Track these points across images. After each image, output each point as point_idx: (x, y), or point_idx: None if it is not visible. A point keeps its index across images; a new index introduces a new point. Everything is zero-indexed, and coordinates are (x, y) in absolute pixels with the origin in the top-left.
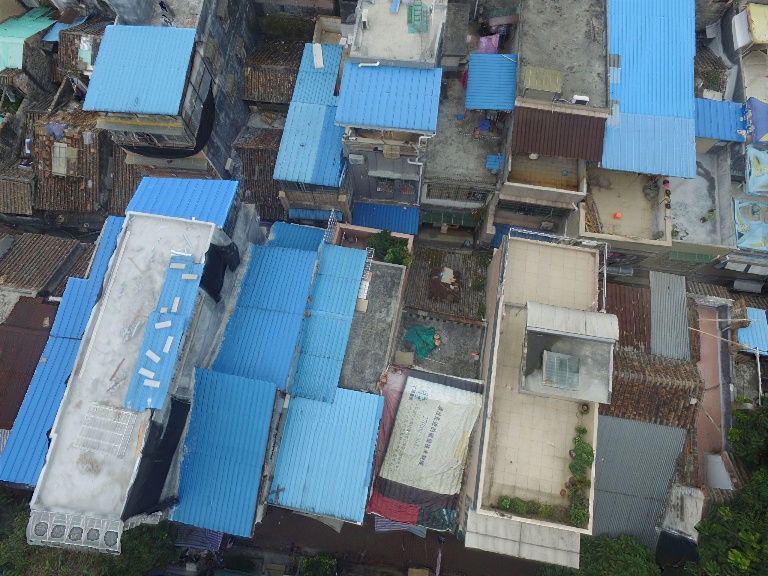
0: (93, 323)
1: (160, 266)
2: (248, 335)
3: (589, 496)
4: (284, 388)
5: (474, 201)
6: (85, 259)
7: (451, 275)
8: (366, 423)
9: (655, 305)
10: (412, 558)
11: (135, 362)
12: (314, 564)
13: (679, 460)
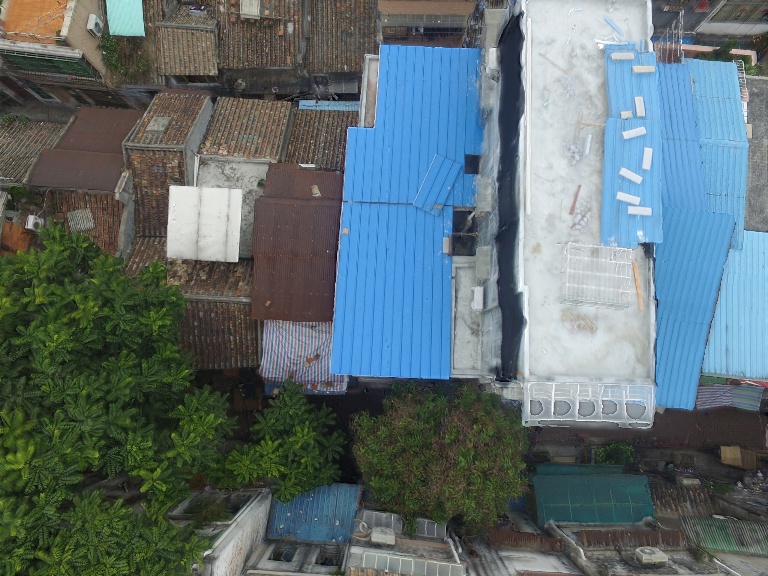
0: None
1: (587, 62)
2: None
3: None
4: None
5: (766, 22)
6: (300, 126)
7: None
8: None
9: None
10: (710, 437)
11: (597, 188)
12: (617, 451)
13: None
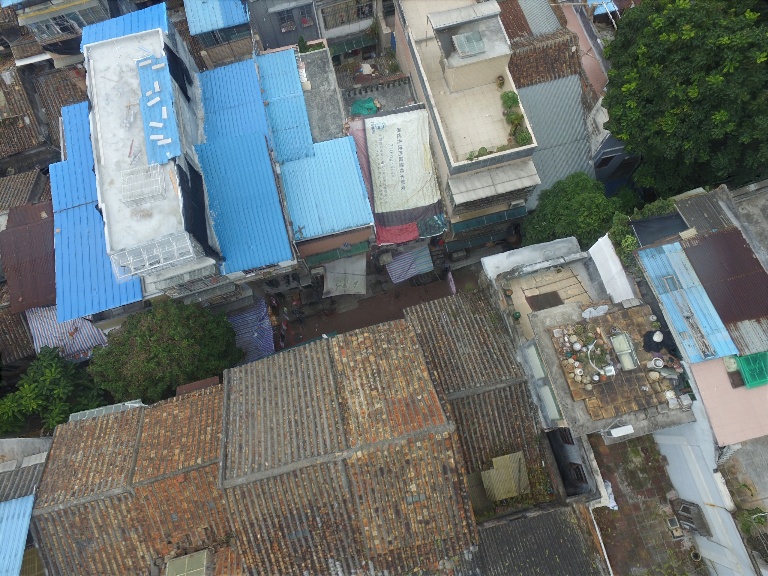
0: (94, 127)
1: (130, 73)
2: (225, 127)
3: (526, 124)
4: (271, 147)
5: (364, 19)
6: None
7: (369, 68)
8: (347, 158)
9: (524, 6)
10: None
11: (143, 138)
12: None
13: (583, 100)
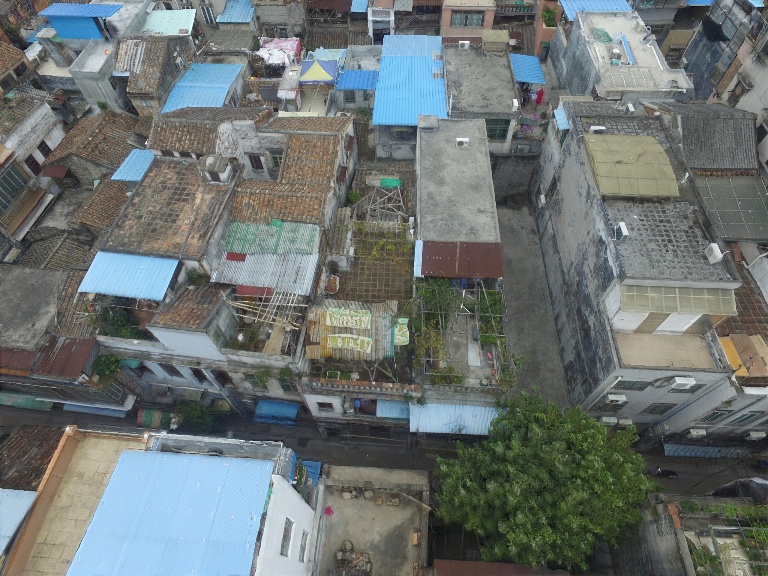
0: None
1: None
2: None
3: None
4: None
5: None
6: None
7: (510, 42)
8: None
9: None
10: None
11: None
12: None
13: None
